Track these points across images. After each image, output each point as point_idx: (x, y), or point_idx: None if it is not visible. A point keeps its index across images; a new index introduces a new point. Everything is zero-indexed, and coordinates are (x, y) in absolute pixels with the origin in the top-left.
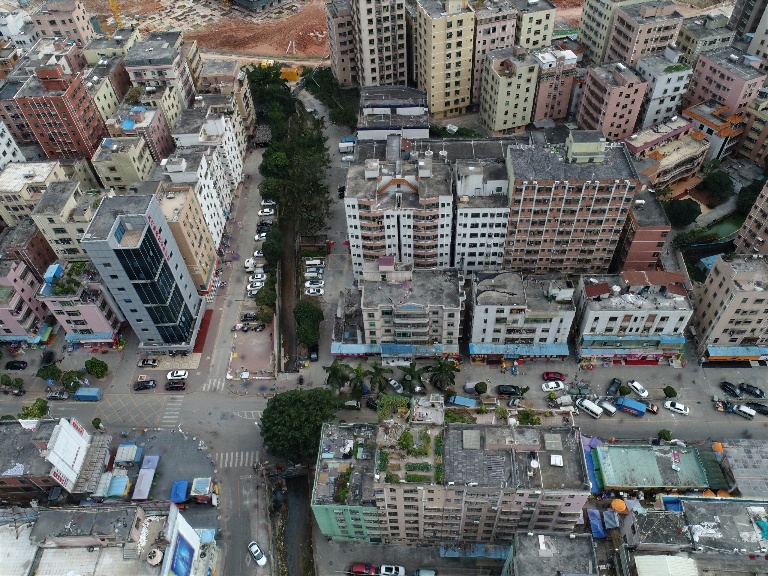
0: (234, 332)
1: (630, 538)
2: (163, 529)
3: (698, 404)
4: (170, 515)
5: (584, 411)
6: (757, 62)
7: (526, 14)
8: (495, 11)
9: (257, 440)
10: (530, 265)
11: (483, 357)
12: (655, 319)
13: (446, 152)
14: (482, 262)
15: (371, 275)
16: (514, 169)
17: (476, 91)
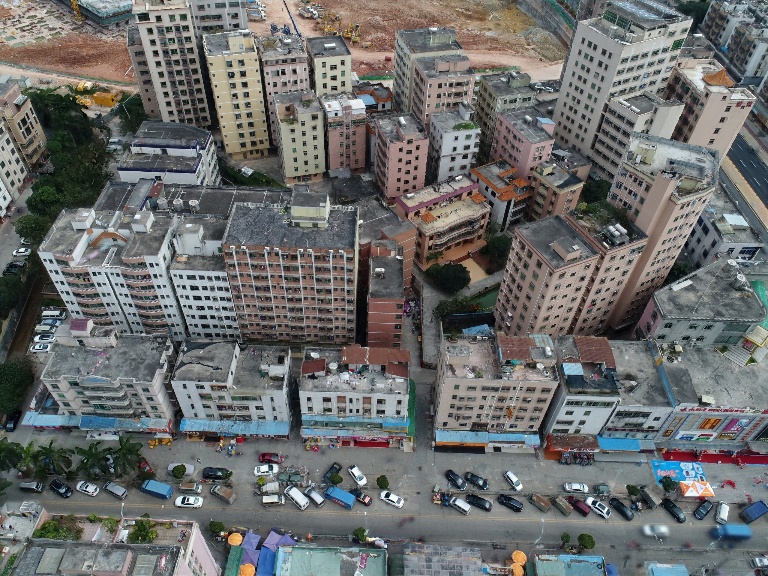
0: None
1: None
2: None
3: (417, 495)
4: None
5: (291, 500)
6: (550, 125)
7: (317, 58)
8: (284, 53)
9: None
10: (270, 331)
11: (196, 434)
12: (371, 401)
13: (196, 202)
14: (217, 325)
15: (65, 339)
16: (230, 230)
17: (275, 134)
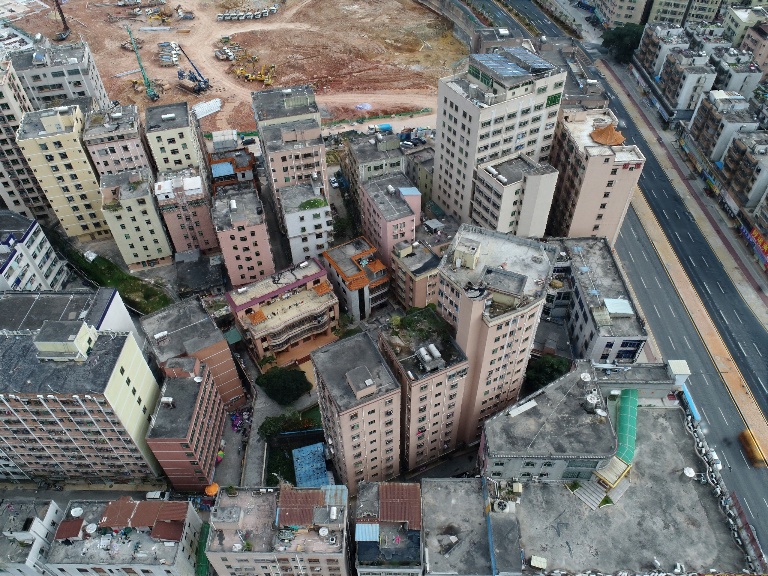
0: None
1: None
2: None
3: None
4: None
5: None
6: (414, 196)
7: (150, 133)
8: (110, 129)
9: None
10: (55, 468)
11: None
12: (135, 571)
13: None
14: None
15: None
16: None
17: None
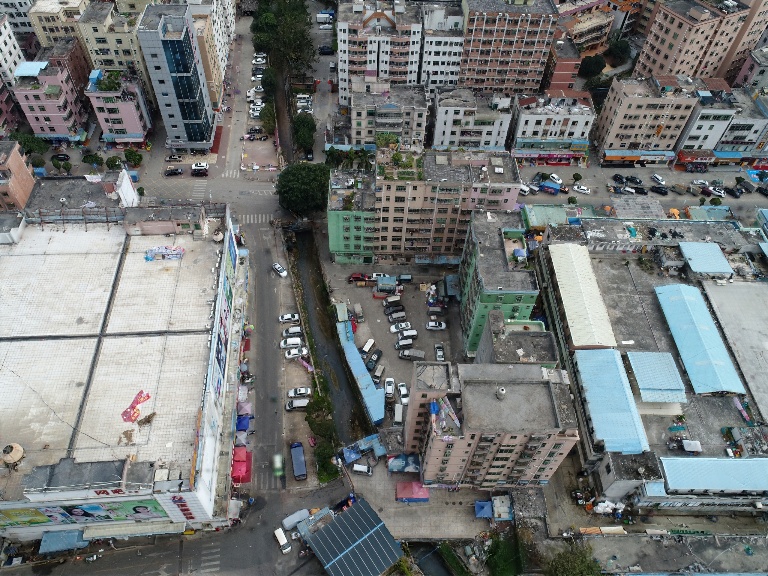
0: (242, 141)
1: (546, 245)
2: (220, 225)
3: (597, 188)
4: (227, 211)
5: None
6: None
7: None
8: None
9: (270, 208)
10: None
11: None
12: (568, 123)
13: None
14: None
15: (358, 86)
16: (468, 6)
17: None
